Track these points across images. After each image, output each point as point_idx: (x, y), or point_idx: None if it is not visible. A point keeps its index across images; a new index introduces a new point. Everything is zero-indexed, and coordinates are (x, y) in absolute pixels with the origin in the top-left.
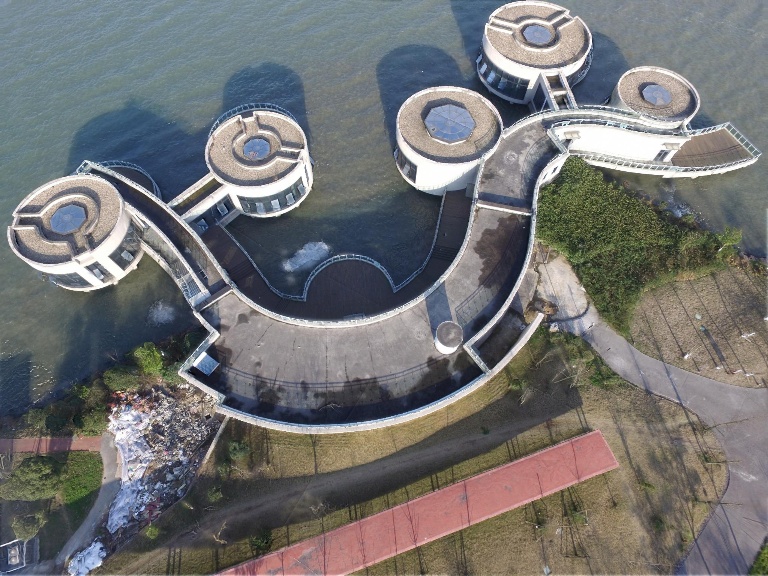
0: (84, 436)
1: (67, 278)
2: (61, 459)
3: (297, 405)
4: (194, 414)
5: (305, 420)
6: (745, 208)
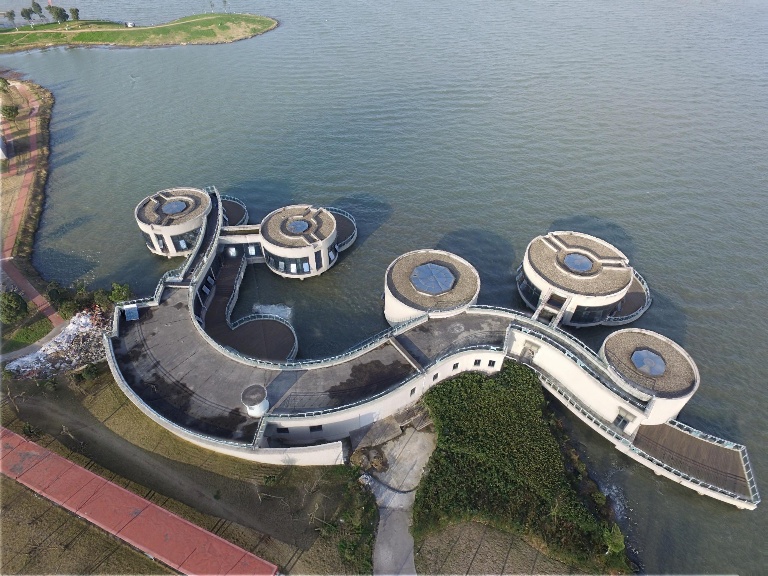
0: (60, 315)
1: (146, 236)
2: (39, 318)
3: (140, 371)
4: None
5: (132, 382)
6: None
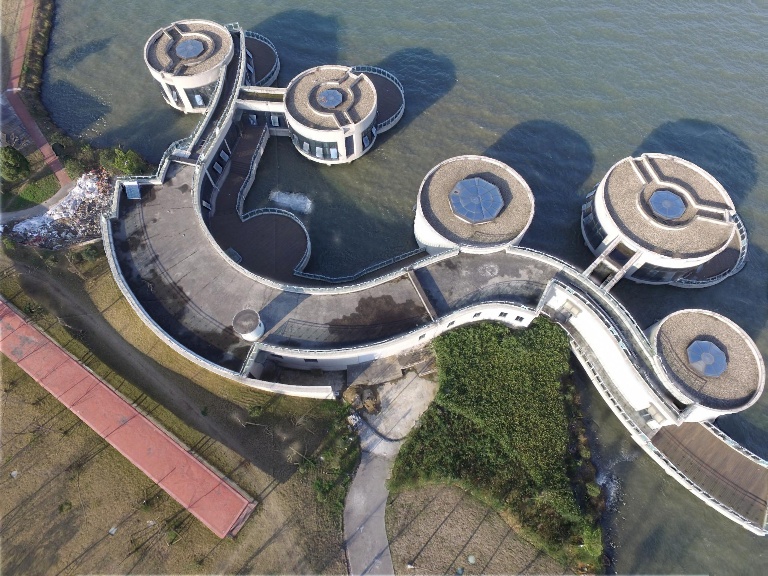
0: (67, 173)
1: None
2: (46, 173)
3: (137, 264)
4: None
5: (129, 276)
6: None
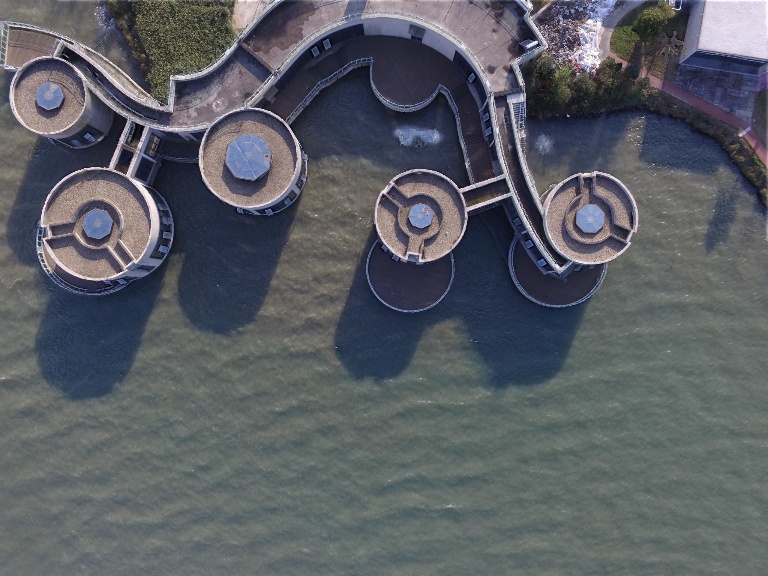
0: None
1: None
2: (635, 58)
3: None
4: None
5: None
6: None
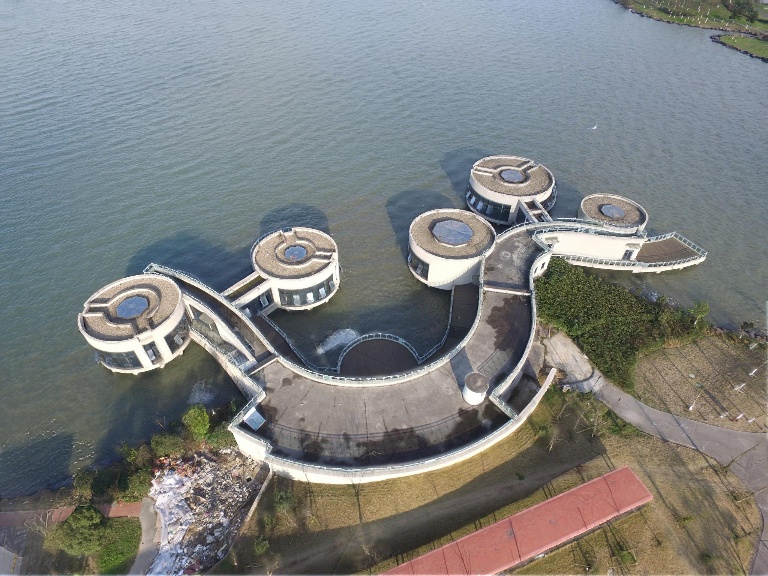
0: (124, 502)
1: (123, 358)
2: None
3: (340, 454)
4: (235, 477)
5: (349, 467)
6: None
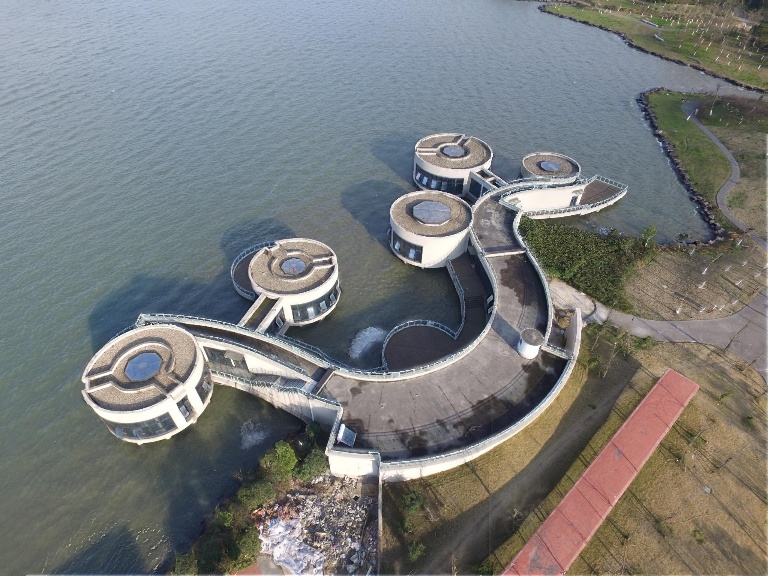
0: (237, 571)
1: (155, 424)
2: None
3: (444, 440)
4: (342, 500)
5: (459, 449)
6: (639, 220)
